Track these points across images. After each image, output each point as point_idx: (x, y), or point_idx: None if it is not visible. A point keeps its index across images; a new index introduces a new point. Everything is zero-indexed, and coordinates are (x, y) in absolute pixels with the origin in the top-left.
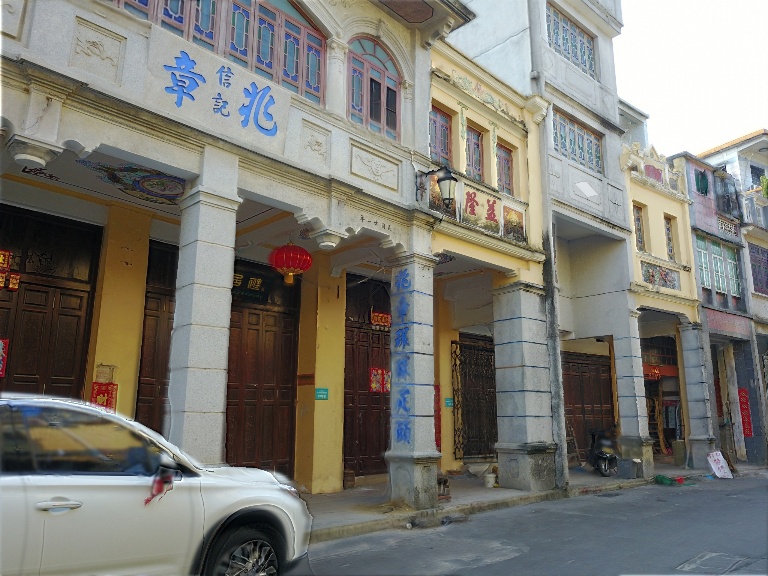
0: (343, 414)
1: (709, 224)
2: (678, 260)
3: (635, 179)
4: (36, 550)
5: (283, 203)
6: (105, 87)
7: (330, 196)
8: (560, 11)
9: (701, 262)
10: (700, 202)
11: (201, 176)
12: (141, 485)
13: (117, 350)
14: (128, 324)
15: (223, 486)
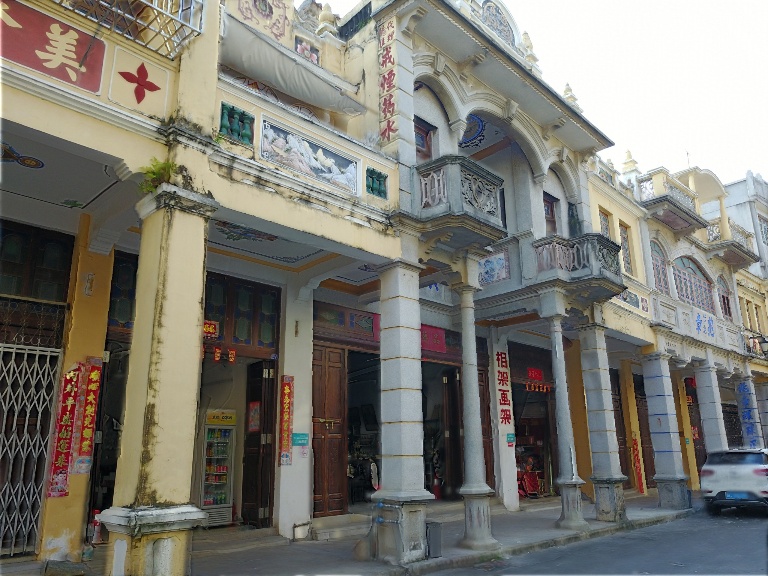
0: None
1: None
2: None
3: None
4: None
5: (719, 363)
6: None
7: (728, 357)
8: (762, 218)
9: None
10: None
11: (708, 360)
12: None
13: (635, 425)
14: (635, 413)
15: None
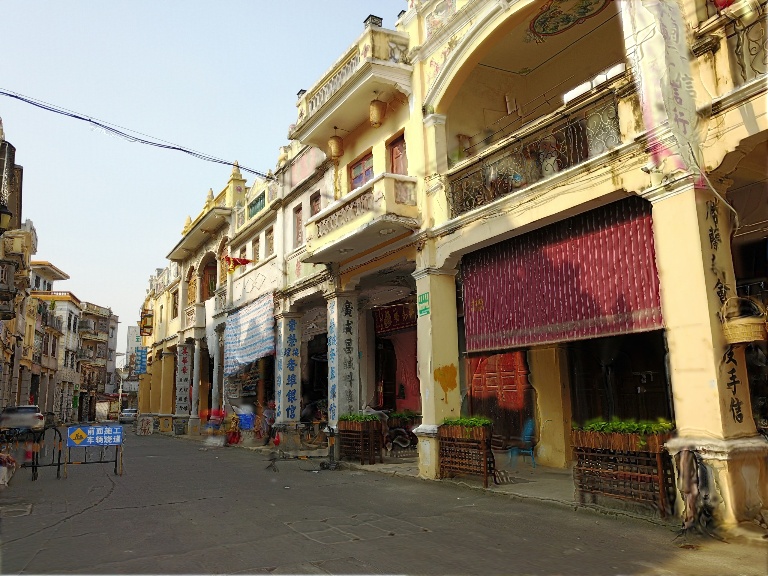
0: None
1: None
2: (29, 344)
3: (27, 313)
4: None
5: None
6: None
7: None
8: None
9: None
10: (38, 318)
11: None
12: None
13: None
14: None
15: None
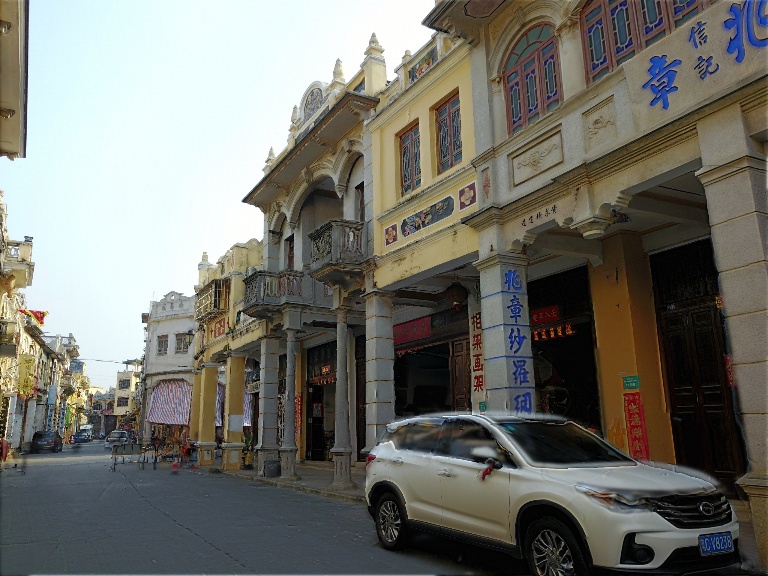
0: None
1: None
2: None
3: None
4: (439, 495)
5: None
6: (608, 148)
7: None
8: None
9: None
10: None
11: None
12: (477, 469)
13: None
14: None
15: (524, 478)
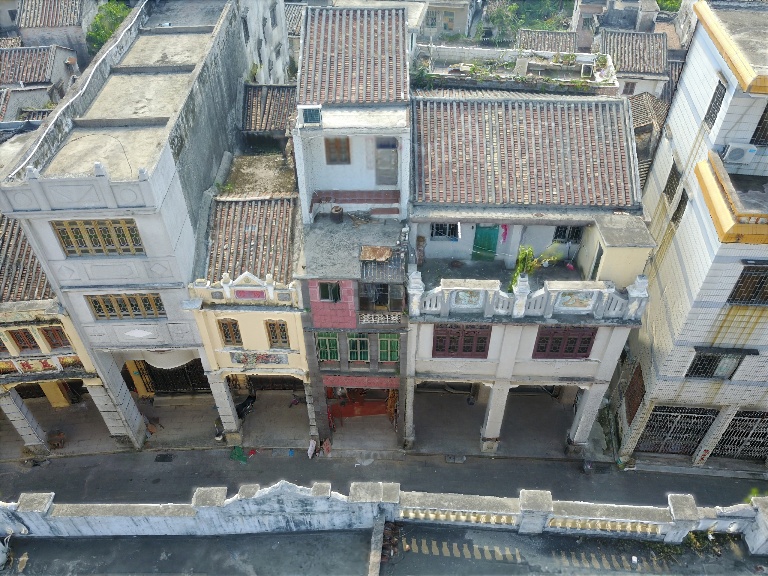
0: (57, 385)
1: (340, 321)
2: None
3: None
4: None
5: None
6: None
7: None
8: (76, 220)
9: (325, 345)
10: (325, 308)
11: None
12: None
13: None
14: None
15: None
